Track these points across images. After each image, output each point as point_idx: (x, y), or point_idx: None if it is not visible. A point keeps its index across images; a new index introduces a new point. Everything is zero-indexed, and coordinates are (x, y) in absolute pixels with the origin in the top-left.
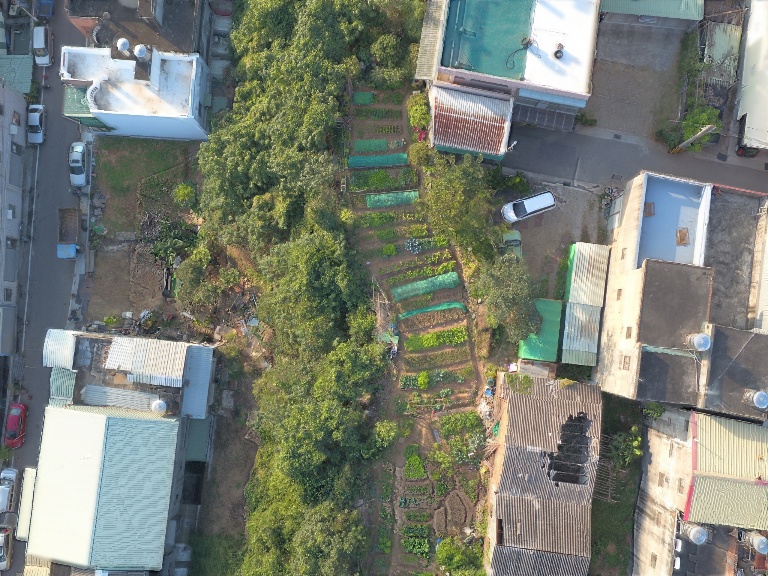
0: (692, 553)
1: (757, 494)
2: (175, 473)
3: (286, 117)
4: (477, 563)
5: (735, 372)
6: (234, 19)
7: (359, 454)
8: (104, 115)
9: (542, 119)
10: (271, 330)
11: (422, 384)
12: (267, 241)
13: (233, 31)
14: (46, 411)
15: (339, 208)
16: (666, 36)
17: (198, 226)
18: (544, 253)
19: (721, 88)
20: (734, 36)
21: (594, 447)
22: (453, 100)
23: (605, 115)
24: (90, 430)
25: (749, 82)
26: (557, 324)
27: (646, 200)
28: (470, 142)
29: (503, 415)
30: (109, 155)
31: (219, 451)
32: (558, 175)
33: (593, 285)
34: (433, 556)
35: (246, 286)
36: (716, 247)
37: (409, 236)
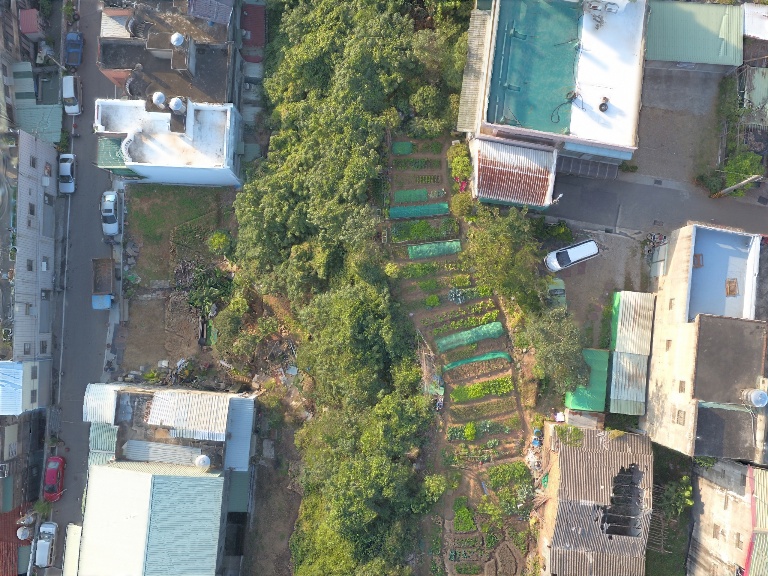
0: None
1: None
2: None
3: (326, 170)
4: None
5: None
6: (266, 67)
7: (409, 509)
8: (139, 167)
9: (585, 169)
10: (311, 379)
11: (469, 435)
12: (306, 291)
13: (266, 80)
14: (90, 469)
15: (381, 260)
16: (704, 80)
17: (232, 273)
18: (588, 301)
19: (762, 133)
20: None
21: (647, 499)
22: (496, 153)
23: (645, 161)
24: (135, 488)
25: None
26: (604, 374)
27: (694, 251)
28: (514, 194)
29: (553, 467)
30: (141, 203)
31: (261, 501)
32: (600, 222)
33: (639, 334)
34: None
35: (283, 334)
36: (766, 297)
37: (452, 286)
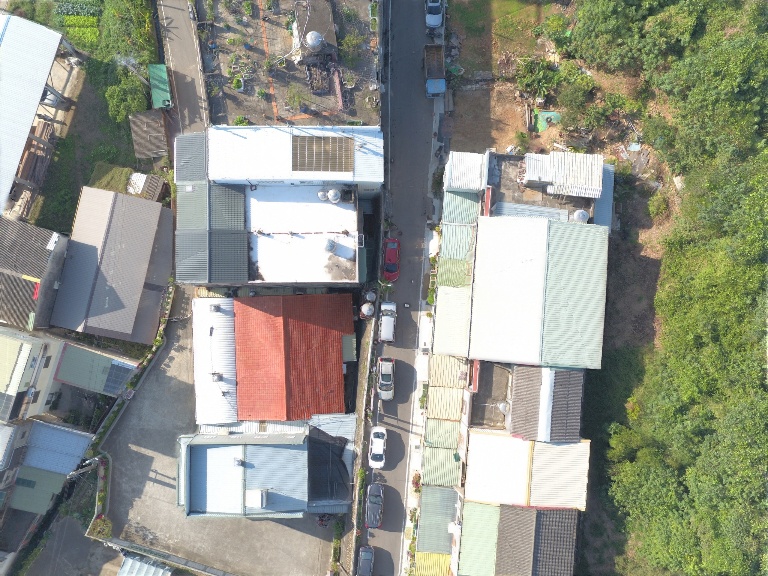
0: None
1: None
2: None
3: None
4: None
5: None
6: None
7: None
8: None
9: None
10: (657, 152)
11: None
12: (664, 60)
13: None
14: (478, 219)
15: None
16: None
17: (555, 63)
18: None
19: None
20: None
21: None
22: None
23: None
24: (530, 233)
25: None
26: None
27: None
28: None
29: None
30: None
31: (609, 271)
32: None
33: None
34: None
35: (621, 114)
36: None
37: None
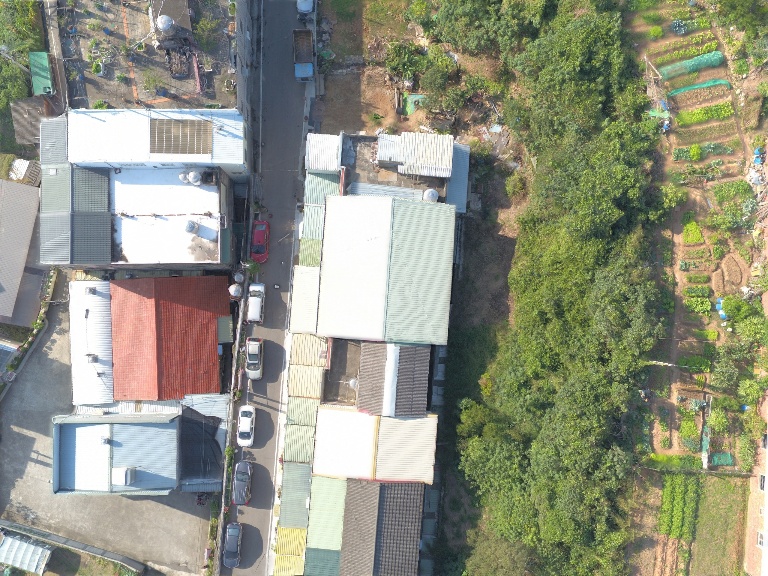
0: None
1: None
2: None
3: None
4: None
5: None
6: None
7: (646, 216)
8: None
9: None
10: None
11: (695, 155)
12: (518, 41)
13: None
14: (327, 199)
15: None
16: None
17: (425, 47)
18: None
19: None
20: None
21: None
22: None
23: None
24: (375, 212)
25: None
26: None
27: None
28: None
29: None
30: None
31: (470, 251)
32: None
33: None
34: (714, 314)
35: (484, 96)
36: None
37: (673, 18)
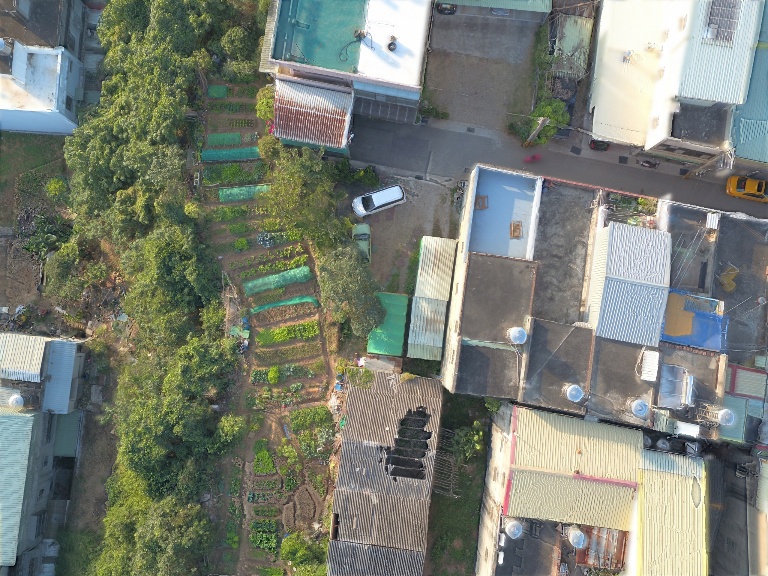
0: (518, 547)
1: (572, 488)
2: (37, 468)
3: (138, 111)
4: (322, 558)
5: (555, 366)
6: None
7: (204, 449)
8: None
9: (385, 112)
10: None
11: (272, 379)
12: (130, 236)
13: (99, 25)
14: None
15: (192, 202)
16: (520, 29)
17: None
18: (395, 247)
19: (569, 81)
20: (585, 28)
21: (431, 441)
22: (294, 93)
23: (458, 108)
24: None
25: (598, 75)
26: (403, 318)
27: (480, 193)
28: (312, 135)
29: None
30: None
31: (87, 446)
32: (410, 169)
33: (439, 279)
34: None
35: (117, 281)
36: (550, 240)
37: (261, 230)
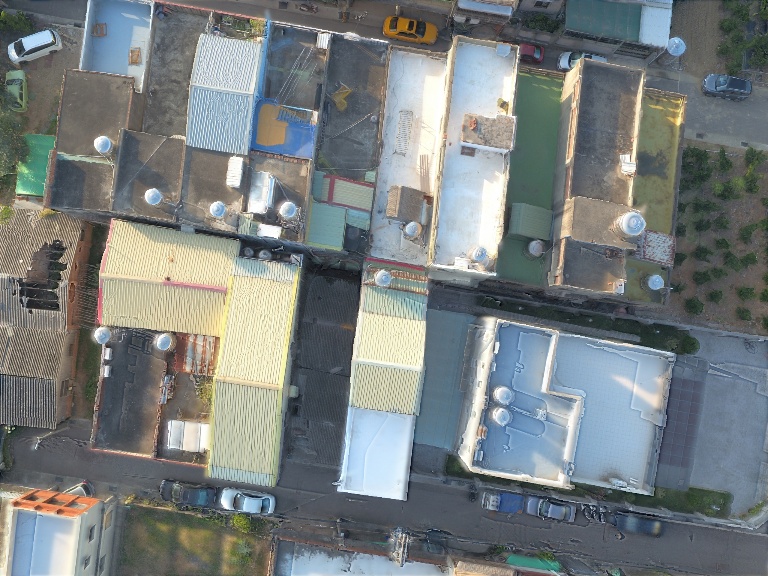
0: (130, 364)
1: (156, 292)
2: None
3: None
4: None
5: (146, 176)
6: None
7: None
8: None
9: None
10: None
11: None
12: None
13: None
14: None
15: None
16: None
17: None
18: (53, 94)
19: None
20: None
21: (64, 272)
22: None
23: None
24: None
25: None
26: None
27: (98, 21)
28: None
29: None
30: None
31: None
32: (69, 16)
33: None
34: None
35: None
36: (168, 66)
37: None
